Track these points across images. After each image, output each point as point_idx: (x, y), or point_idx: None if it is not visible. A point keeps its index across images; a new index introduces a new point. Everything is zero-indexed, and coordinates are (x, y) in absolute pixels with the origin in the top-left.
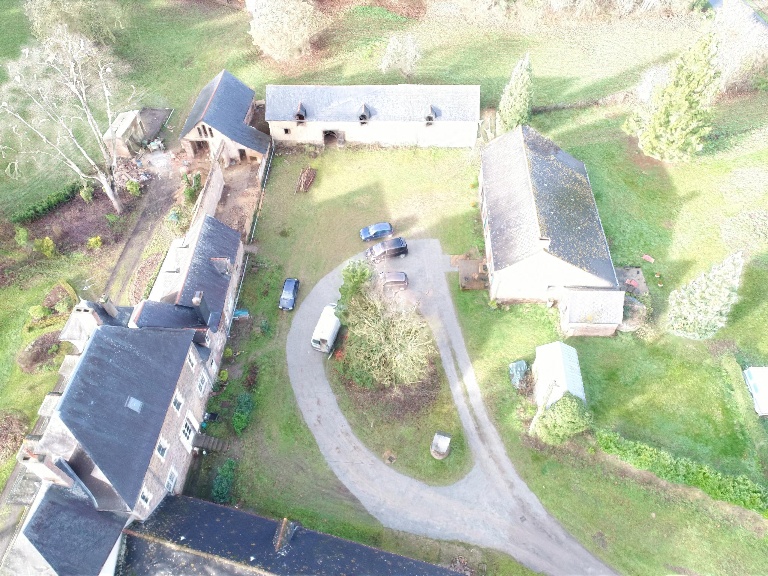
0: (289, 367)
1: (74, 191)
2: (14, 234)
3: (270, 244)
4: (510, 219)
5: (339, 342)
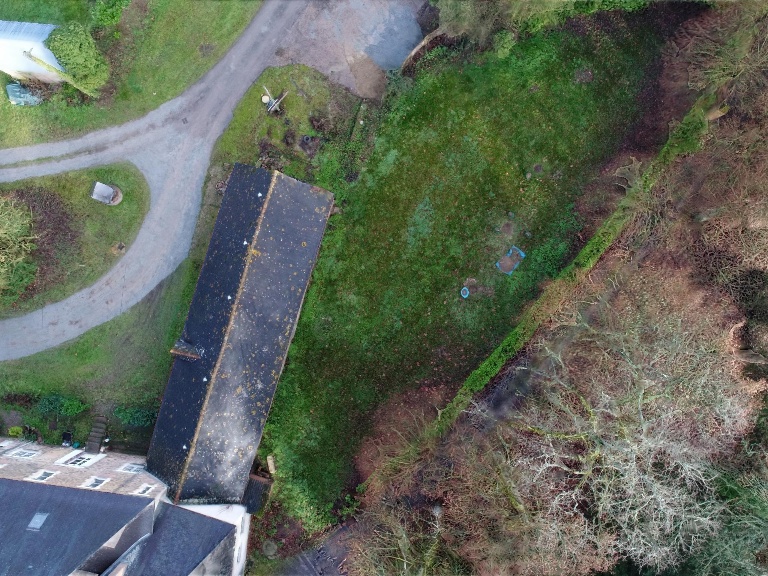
0: (8, 359)
1: None
2: None
3: None
4: None
5: None
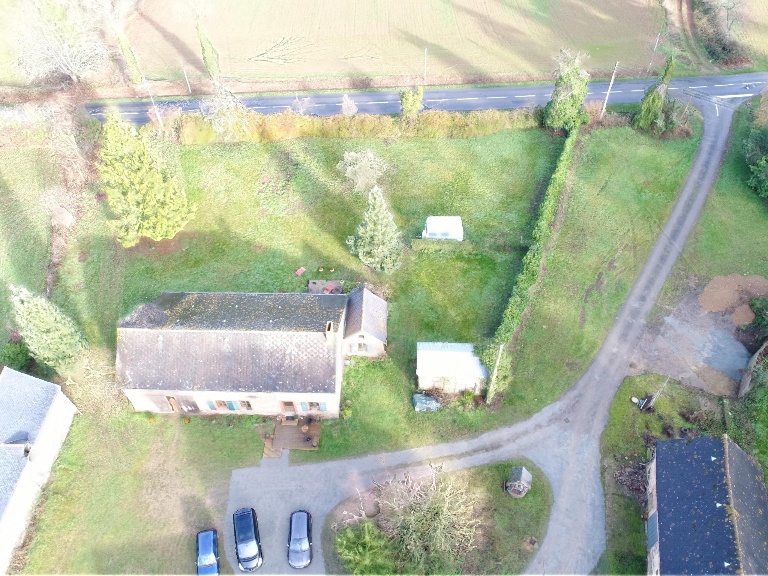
0: None
1: None
2: None
3: None
4: (269, 364)
5: None
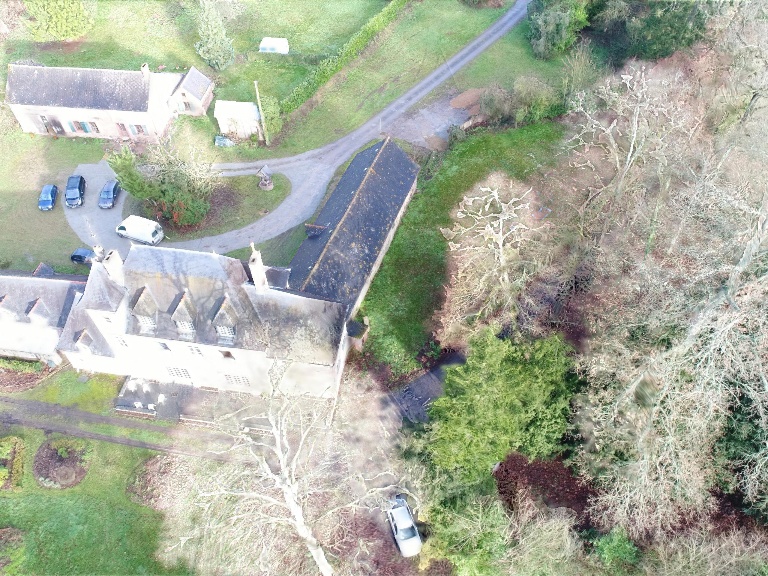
0: None
1: None
2: None
3: None
4: (105, 92)
5: None
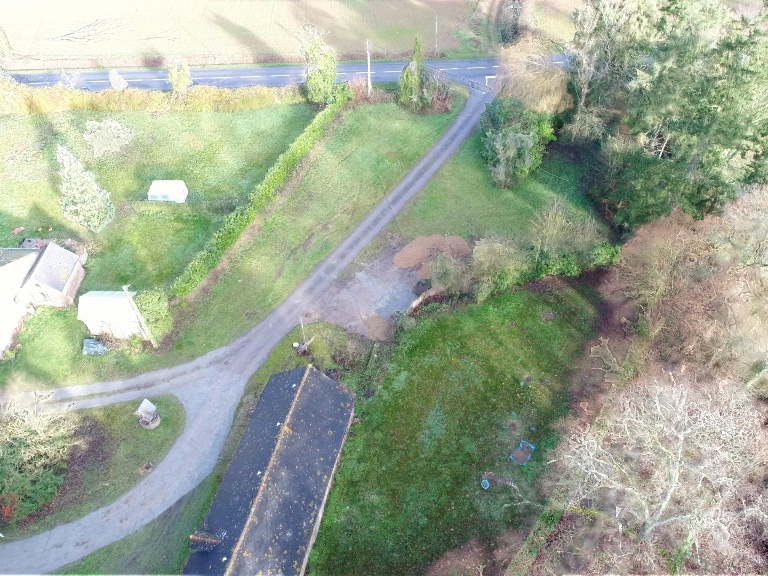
0: None
1: None
2: None
3: None
4: None
5: None
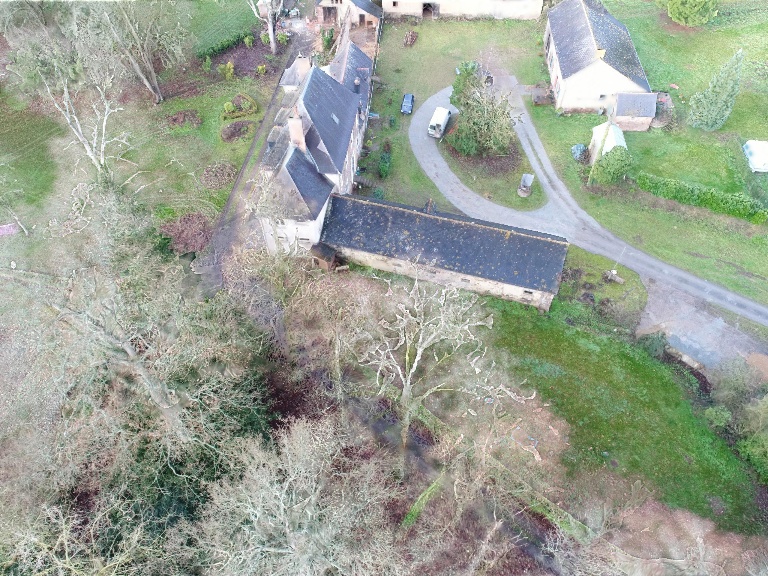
0: (412, 146)
1: (239, 40)
2: (198, 66)
3: (388, 76)
4: (573, 47)
5: (446, 133)
